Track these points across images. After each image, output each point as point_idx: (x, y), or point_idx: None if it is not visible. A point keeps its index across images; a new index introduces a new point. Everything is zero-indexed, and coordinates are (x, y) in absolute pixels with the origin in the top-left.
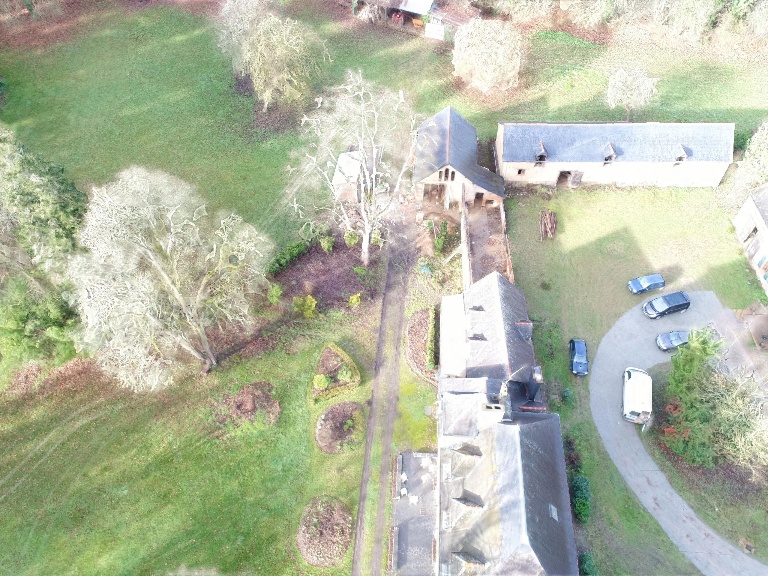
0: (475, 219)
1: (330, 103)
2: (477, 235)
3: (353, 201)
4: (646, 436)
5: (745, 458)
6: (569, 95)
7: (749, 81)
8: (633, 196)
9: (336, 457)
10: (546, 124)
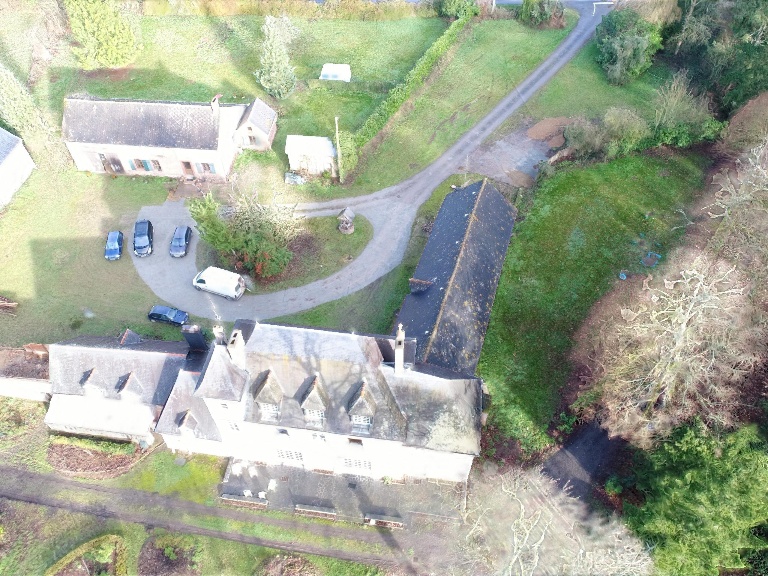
0: None
1: None
2: None
3: None
4: (256, 290)
5: None
6: None
7: None
8: (6, 225)
9: (205, 572)
10: None
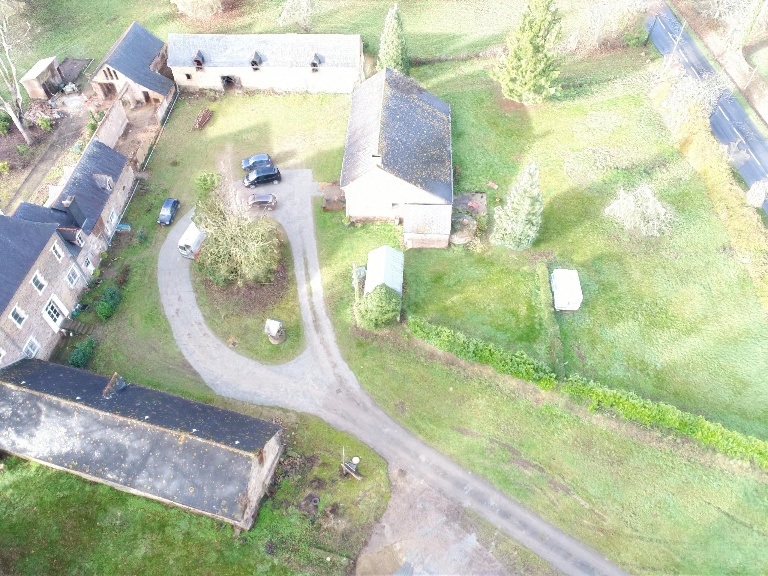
0: (142, 114)
1: (65, 26)
2: (137, 126)
3: (43, 98)
4: None
5: (239, 274)
6: (274, 22)
7: (436, 12)
8: (286, 99)
9: None
10: (202, 34)
